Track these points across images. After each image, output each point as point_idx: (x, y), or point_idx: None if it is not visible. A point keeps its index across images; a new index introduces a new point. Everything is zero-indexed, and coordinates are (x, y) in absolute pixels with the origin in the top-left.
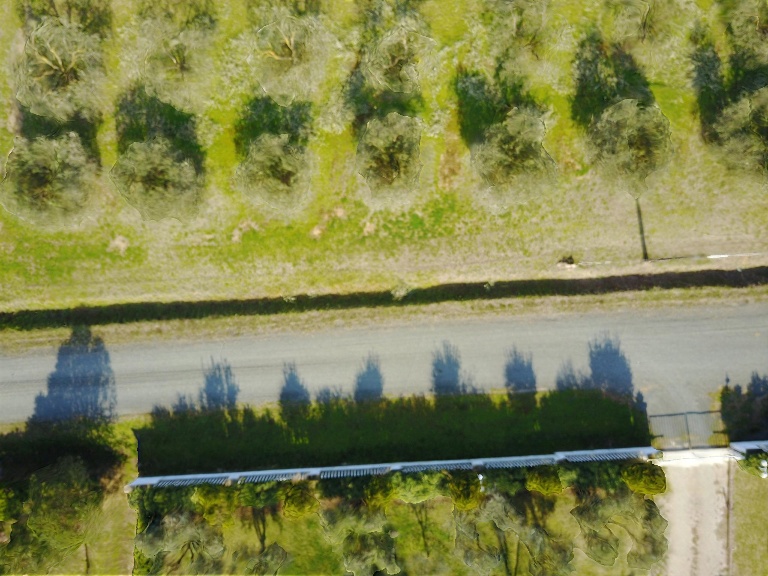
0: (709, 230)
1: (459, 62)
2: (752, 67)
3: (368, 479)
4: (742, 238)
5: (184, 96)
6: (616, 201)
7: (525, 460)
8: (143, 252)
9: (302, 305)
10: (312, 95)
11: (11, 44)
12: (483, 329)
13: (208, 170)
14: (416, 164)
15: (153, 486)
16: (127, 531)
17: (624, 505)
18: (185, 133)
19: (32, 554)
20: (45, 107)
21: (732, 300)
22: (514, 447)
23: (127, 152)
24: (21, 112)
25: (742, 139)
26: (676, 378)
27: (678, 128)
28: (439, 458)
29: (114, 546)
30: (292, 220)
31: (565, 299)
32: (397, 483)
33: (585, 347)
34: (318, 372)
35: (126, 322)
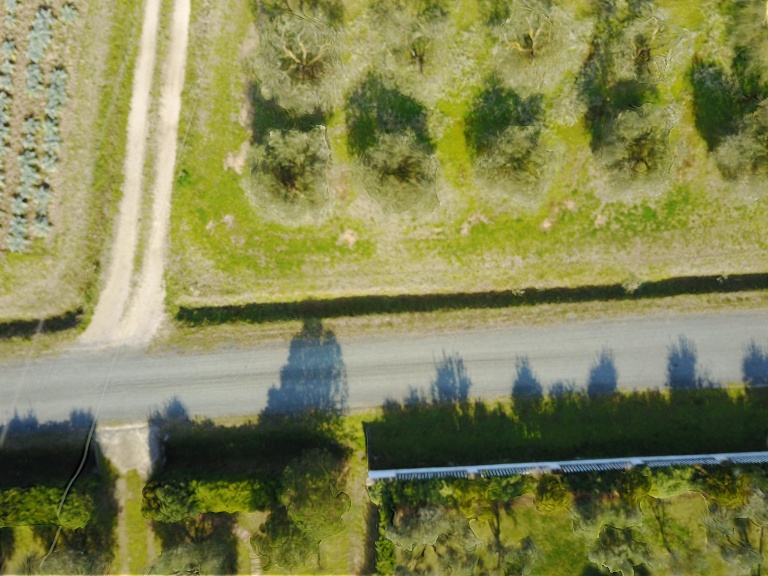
0: None
1: (695, 52)
2: None
3: (615, 473)
4: None
5: (429, 88)
6: None
7: None
8: (372, 245)
9: (532, 298)
10: (544, 87)
11: (243, 38)
12: (720, 323)
13: None
14: (672, 155)
15: (395, 479)
16: (353, 524)
17: None
18: (416, 126)
19: (295, 545)
20: (294, 100)
21: None
22: (752, 442)
23: (379, 144)
24: (252, 106)
25: None
26: None
27: None
28: (674, 453)
29: (343, 539)
30: (522, 213)
31: None
32: None
33: None
34: (551, 366)
35: (356, 315)
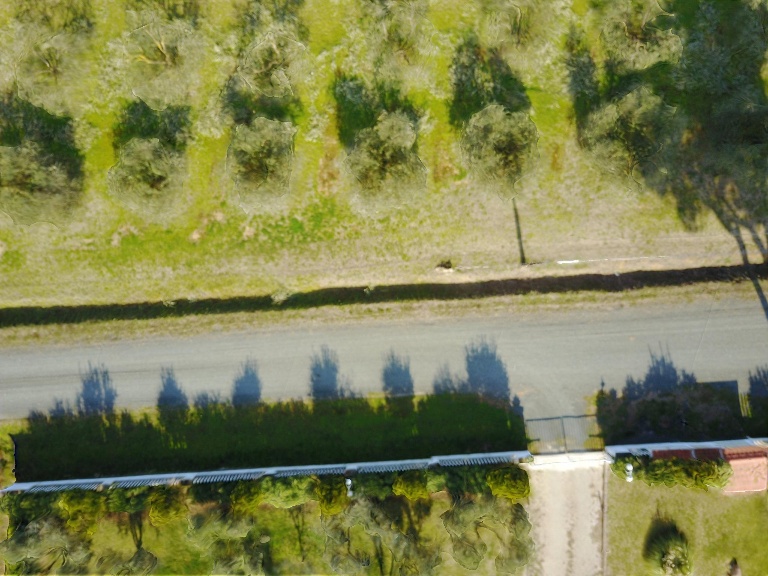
0: (586, 235)
1: (337, 66)
2: (625, 73)
3: None
4: (618, 243)
5: (54, 100)
6: (494, 206)
7: (400, 464)
8: (21, 256)
9: (181, 309)
10: (190, 99)
11: None
12: (361, 333)
13: (87, 174)
14: (283, 169)
15: (24, 492)
16: (6, 537)
17: (485, 509)
18: (62, 137)
19: None
20: None
21: (607, 304)
22: (392, 451)
23: None
24: None
25: (606, 144)
26: (552, 382)
27: (554, 133)
28: (317, 462)
29: None
30: (171, 224)
31: (443, 303)
32: (266, 488)
33: (462, 351)
34: (196, 377)
35: (3, 327)
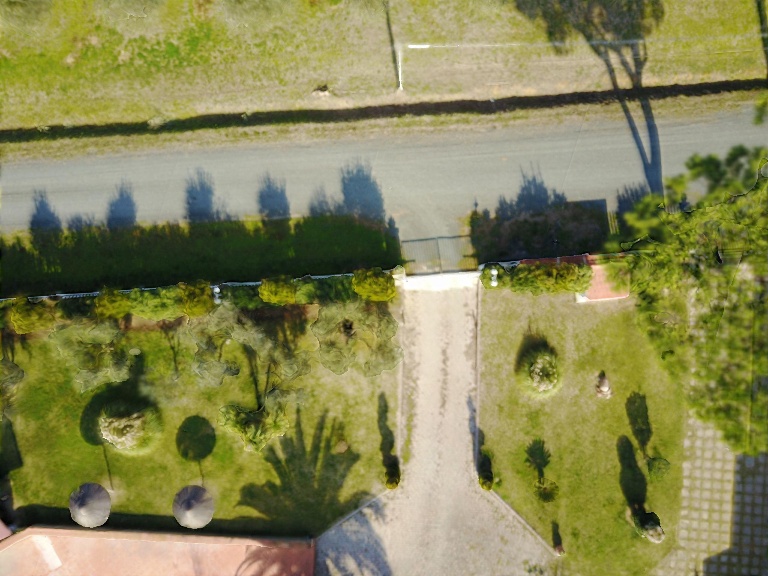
0: (460, 59)
1: None
2: None
3: None
4: (492, 67)
5: None
6: (369, 30)
7: None
8: None
9: (56, 134)
10: None
11: None
12: (237, 156)
13: None
14: None
15: None
16: None
17: (348, 307)
18: None
19: None
20: None
21: (481, 126)
22: (268, 273)
23: None
24: None
25: None
26: (427, 203)
27: None
28: None
29: None
30: (45, 48)
31: (319, 126)
32: (135, 298)
33: (338, 173)
34: (70, 200)
35: None
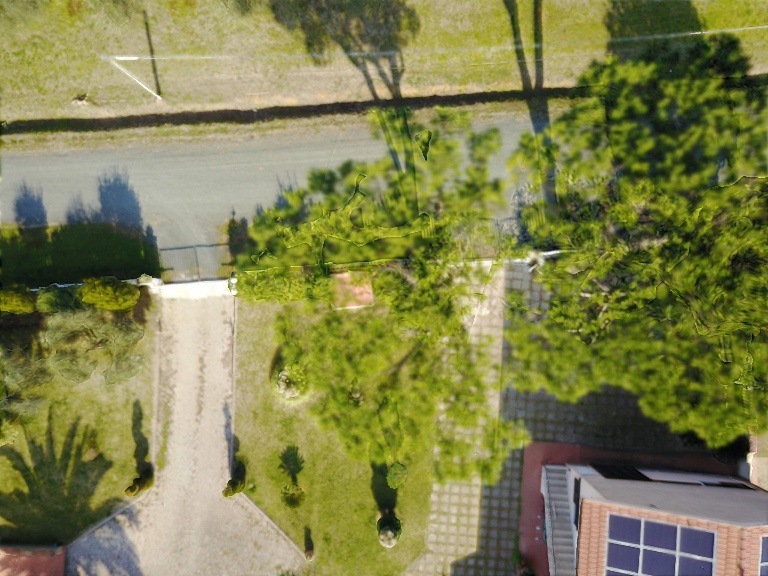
0: (220, 69)
1: None
2: None
3: None
4: (252, 77)
5: None
6: (129, 40)
7: None
8: None
9: None
10: None
11: None
12: None
13: None
14: None
15: None
16: None
17: (76, 316)
18: None
19: None
20: None
21: (239, 136)
22: (24, 281)
23: None
24: None
25: None
26: (185, 212)
27: None
28: None
29: None
30: None
31: (77, 135)
32: None
33: (95, 182)
34: None
35: None
